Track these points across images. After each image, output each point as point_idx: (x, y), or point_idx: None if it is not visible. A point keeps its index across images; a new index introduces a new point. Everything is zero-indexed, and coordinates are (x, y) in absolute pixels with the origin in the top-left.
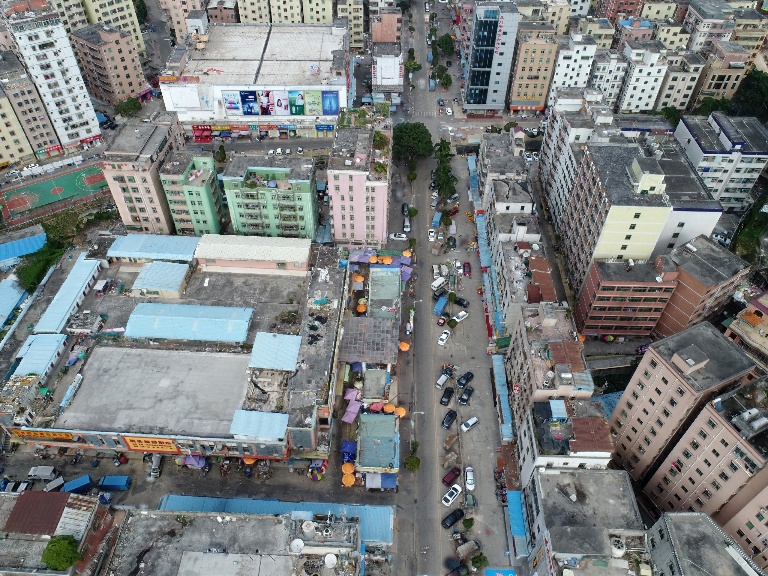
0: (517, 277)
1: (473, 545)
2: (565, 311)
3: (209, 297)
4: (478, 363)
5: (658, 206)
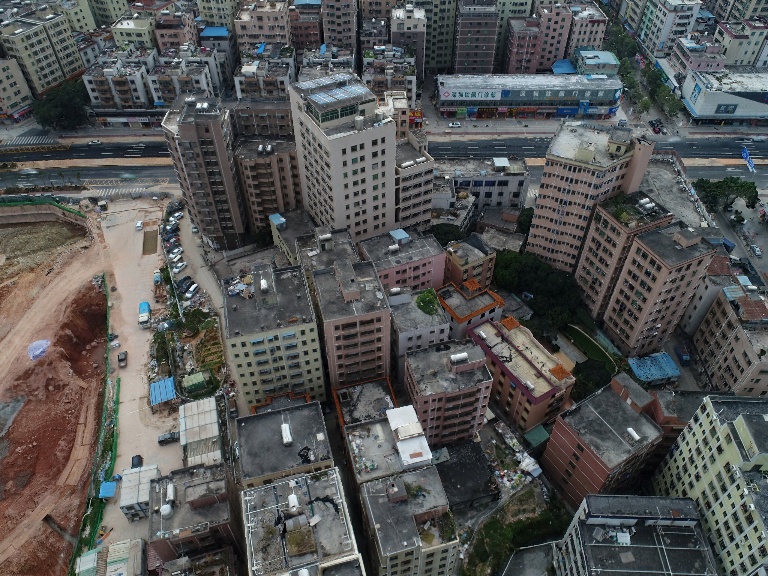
0: None
1: None
2: (763, 365)
3: None
4: None
5: (724, 406)
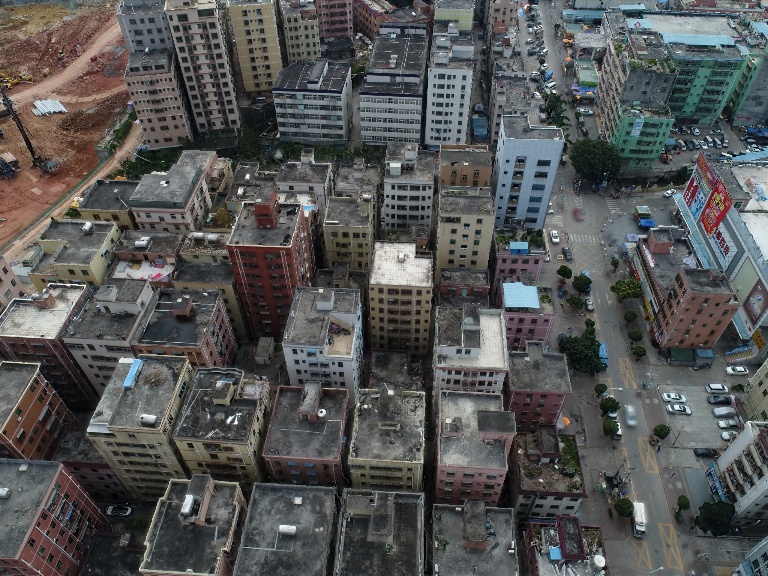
0: (512, 35)
1: None
2: (495, 5)
3: None
4: None
5: None
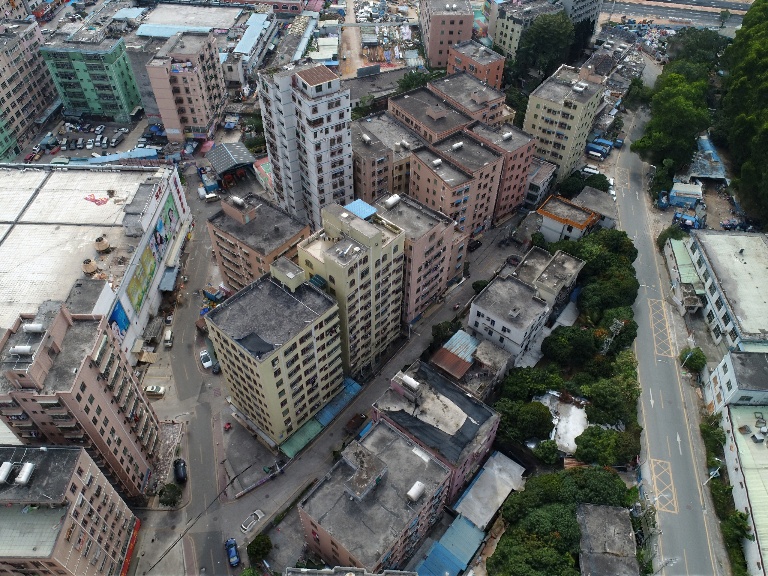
0: None
1: (77, 3)
2: None
3: None
4: None
5: None
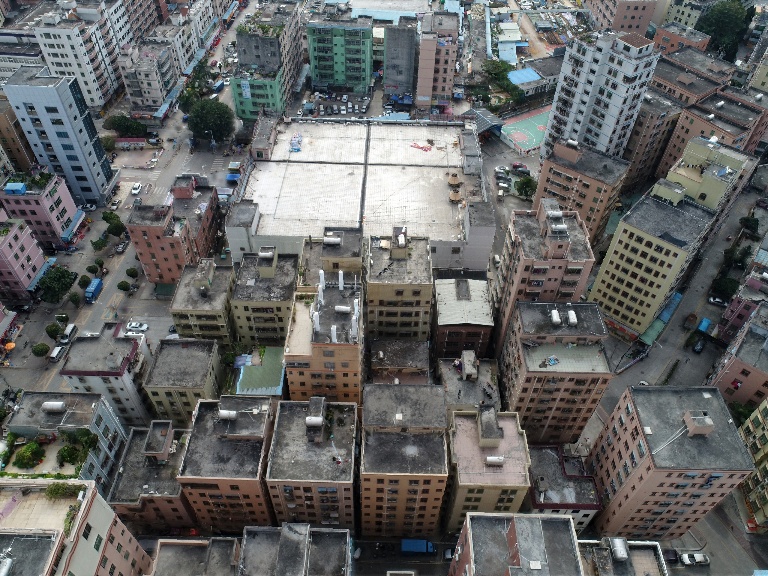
0: (198, 6)
1: None
2: None
3: (378, 27)
4: (234, 32)
5: None
